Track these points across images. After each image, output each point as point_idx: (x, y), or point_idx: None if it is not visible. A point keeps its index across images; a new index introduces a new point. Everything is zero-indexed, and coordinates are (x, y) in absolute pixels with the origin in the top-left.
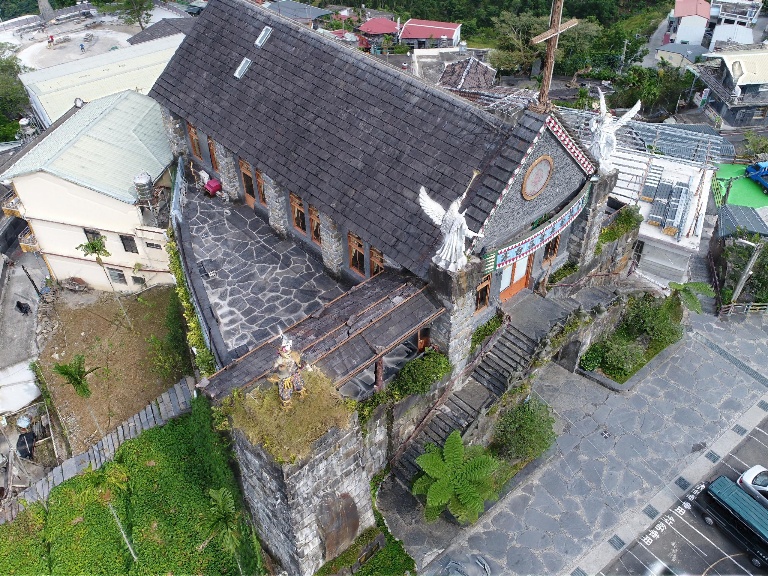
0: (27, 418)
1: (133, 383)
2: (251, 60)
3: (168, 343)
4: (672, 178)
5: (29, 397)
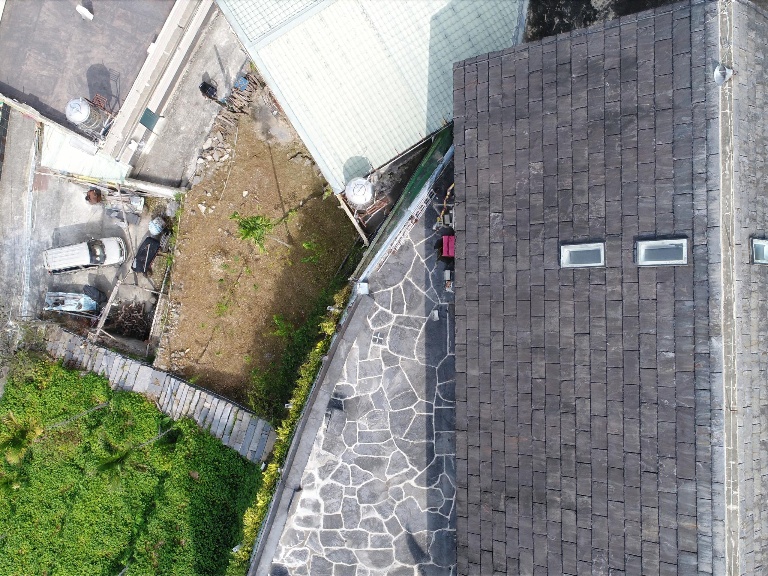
0: (160, 226)
1: (248, 327)
2: (604, 264)
3: (282, 368)
4: None
5: None
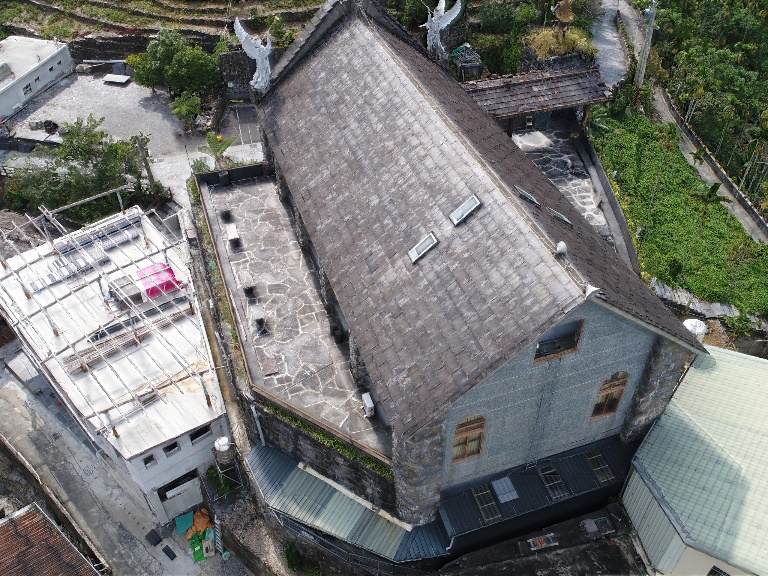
0: None
1: None
2: None
3: None
4: (43, 272)
5: None
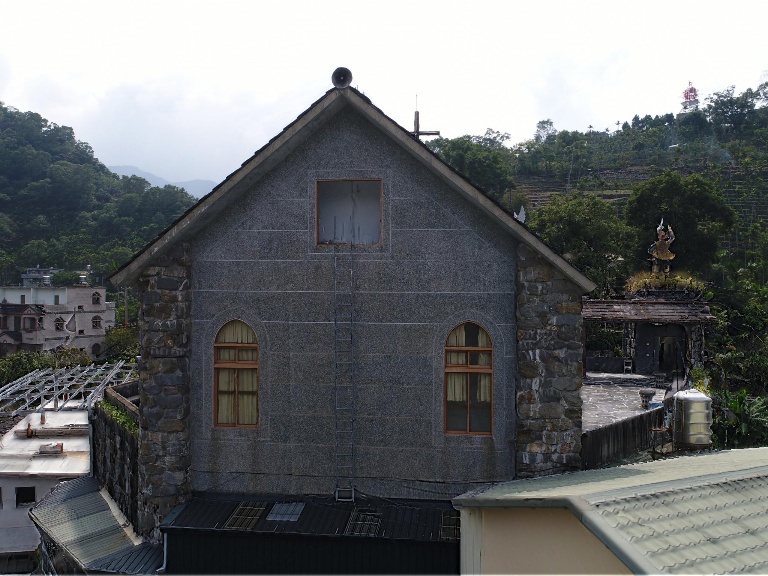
0: None
1: None
2: None
3: None
4: None
5: None
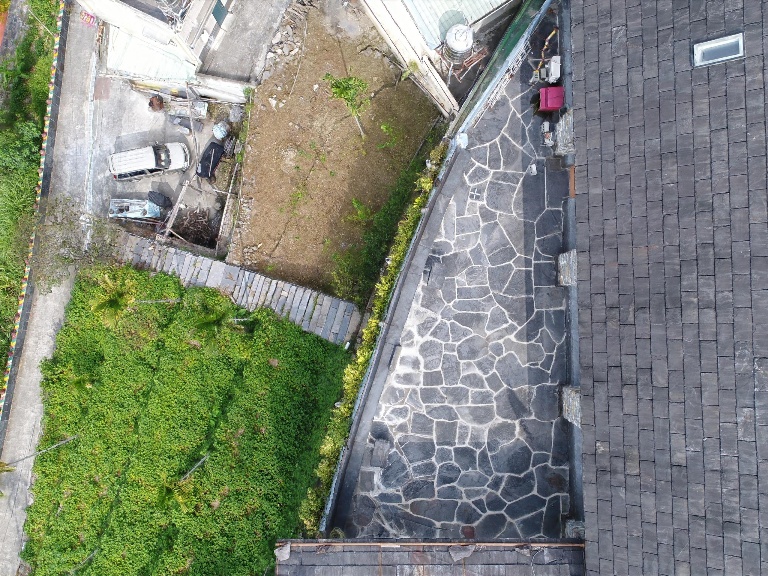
0: (224, 129)
1: (322, 218)
2: (743, 54)
3: (365, 247)
4: None
5: (238, 100)
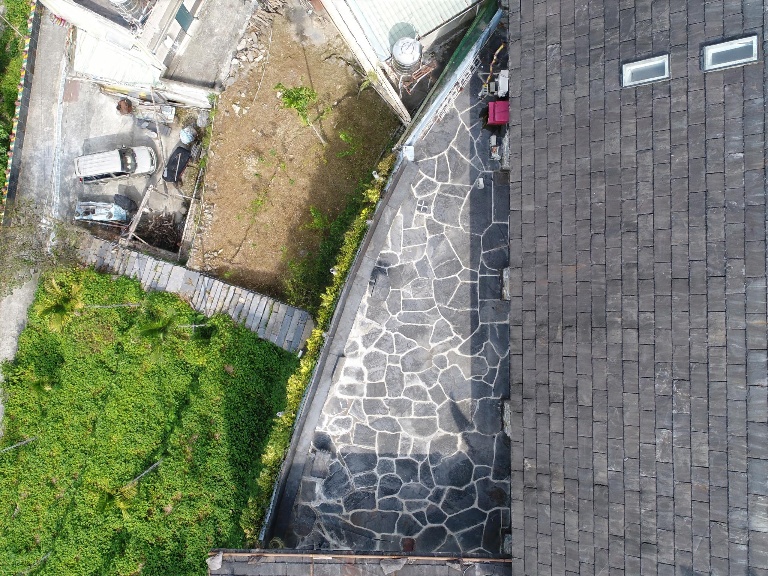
0: (191, 134)
1: (282, 225)
2: (669, 75)
3: (319, 256)
4: None
5: (206, 105)
